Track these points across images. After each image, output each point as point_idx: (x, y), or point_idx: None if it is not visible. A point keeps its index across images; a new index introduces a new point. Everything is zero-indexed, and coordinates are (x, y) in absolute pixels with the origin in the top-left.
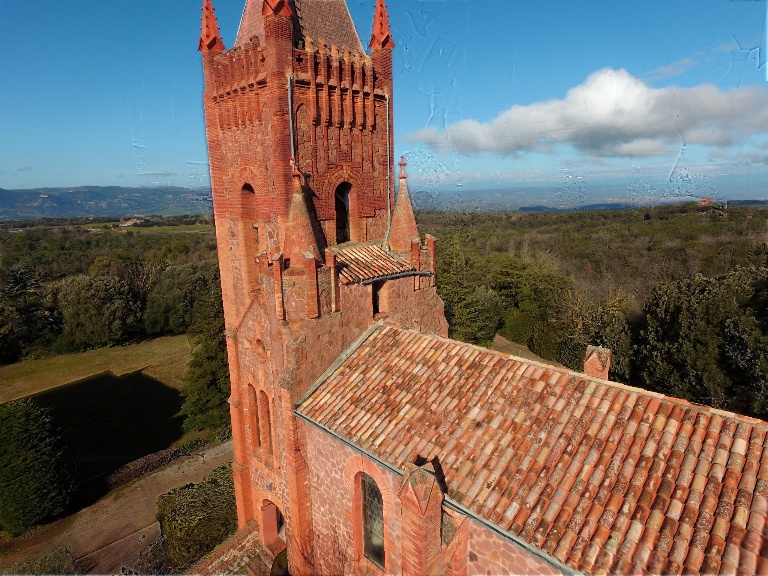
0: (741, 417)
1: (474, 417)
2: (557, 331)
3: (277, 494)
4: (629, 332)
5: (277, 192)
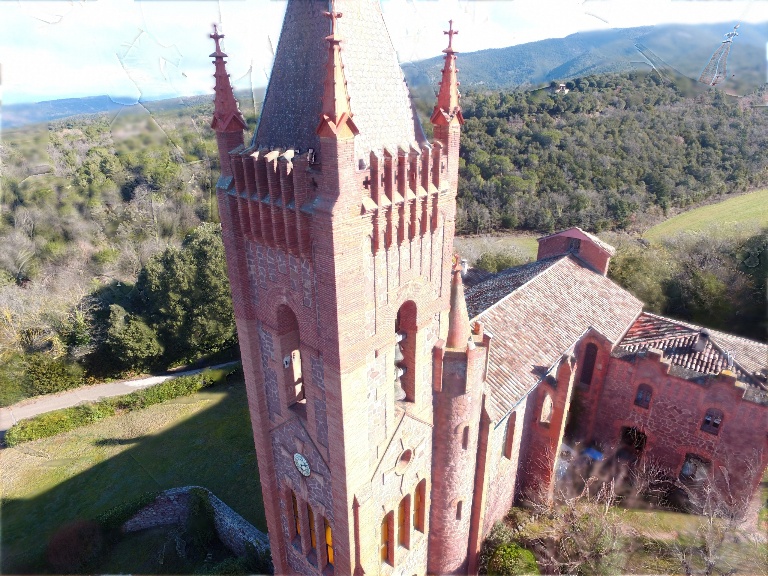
0: (522, 287)
1: (512, 345)
2: (5, 366)
3: (410, 567)
4: (139, 317)
5: (443, 291)
